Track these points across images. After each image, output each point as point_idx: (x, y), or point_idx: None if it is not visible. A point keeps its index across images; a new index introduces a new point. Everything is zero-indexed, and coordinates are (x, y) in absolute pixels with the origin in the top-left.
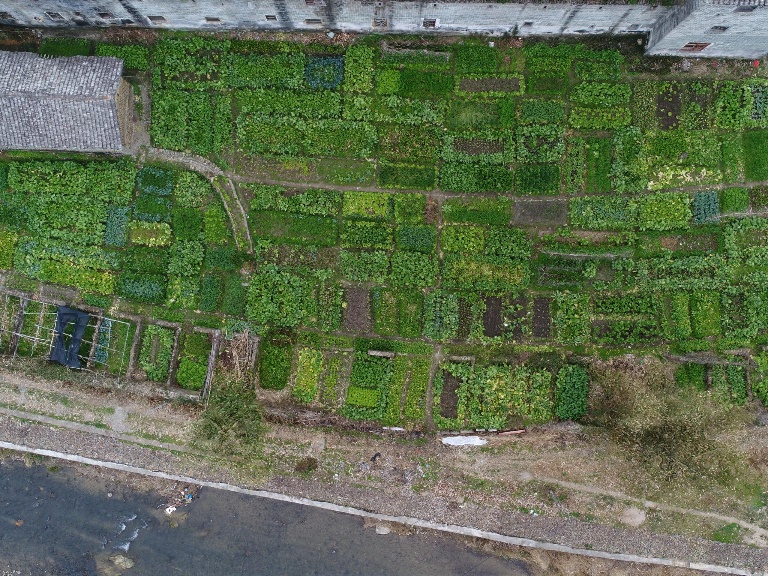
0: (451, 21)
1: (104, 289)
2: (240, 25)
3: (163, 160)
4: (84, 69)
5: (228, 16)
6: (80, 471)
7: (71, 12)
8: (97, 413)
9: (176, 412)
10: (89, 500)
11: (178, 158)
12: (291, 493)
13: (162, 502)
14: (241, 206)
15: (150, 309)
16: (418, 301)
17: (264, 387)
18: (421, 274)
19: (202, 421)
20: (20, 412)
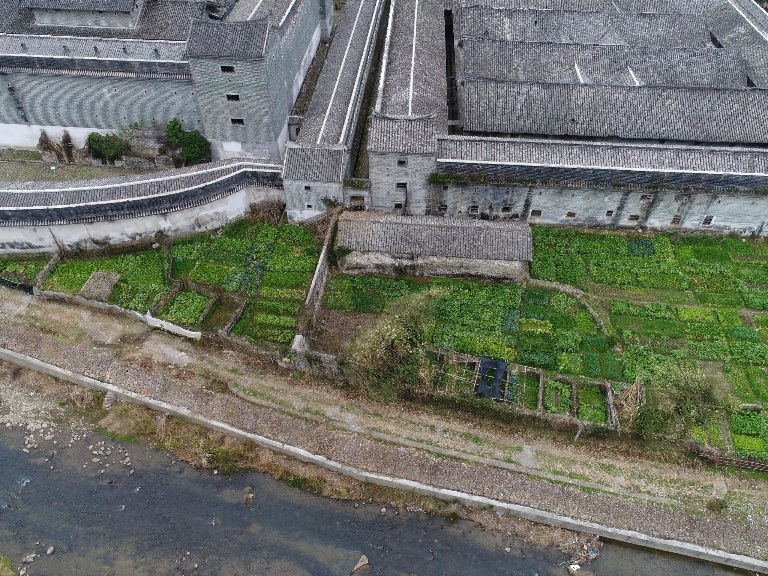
0: (722, 219)
1: (506, 357)
2: (584, 221)
3: (540, 285)
4: (505, 223)
5: (583, 211)
6: (478, 520)
7: (487, 206)
8: (506, 451)
9: (579, 452)
10: (485, 555)
11: (551, 285)
12: (705, 542)
13: (563, 560)
14: (603, 311)
15: (544, 373)
16: (763, 375)
17: (657, 431)
18: (760, 353)
19: (605, 461)
20: (435, 447)
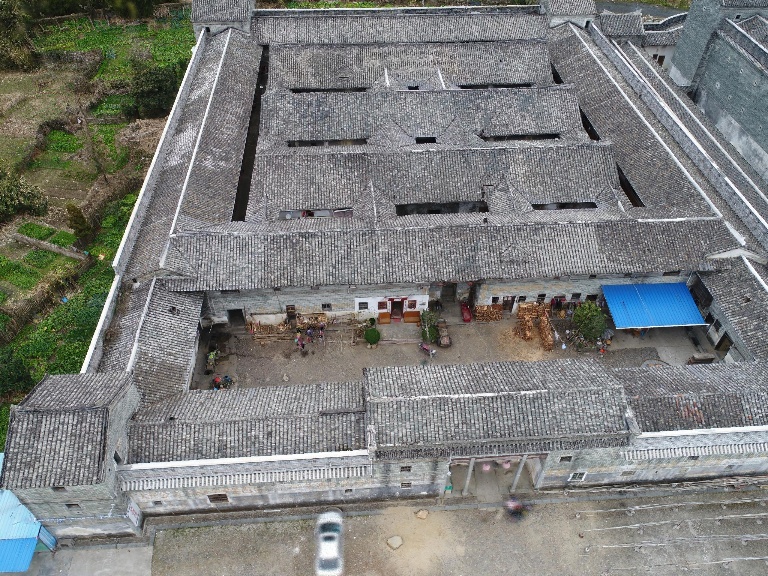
0: None
1: None
2: None
3: None
4: None
5: None
6: None
7: None
8: None
9: None
10: None
11: None
12: None
13: None
14: None
15: None
16: None
17: None
18: None
19: None
20: None
